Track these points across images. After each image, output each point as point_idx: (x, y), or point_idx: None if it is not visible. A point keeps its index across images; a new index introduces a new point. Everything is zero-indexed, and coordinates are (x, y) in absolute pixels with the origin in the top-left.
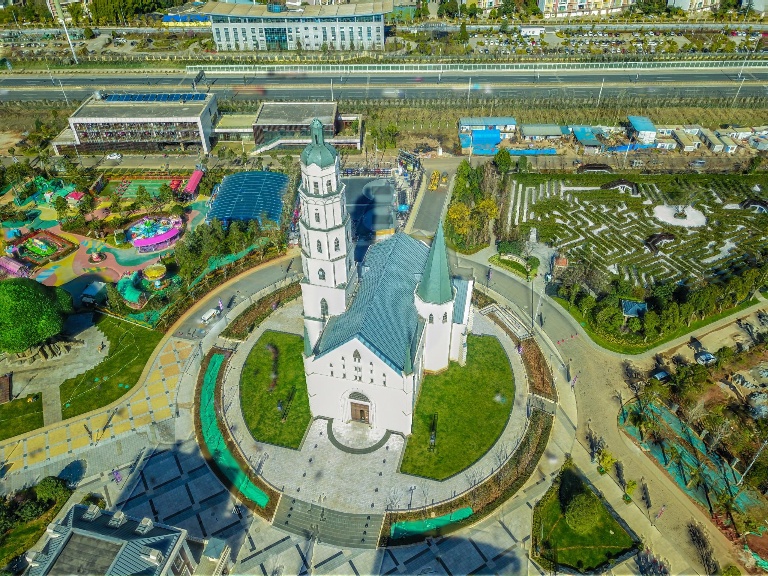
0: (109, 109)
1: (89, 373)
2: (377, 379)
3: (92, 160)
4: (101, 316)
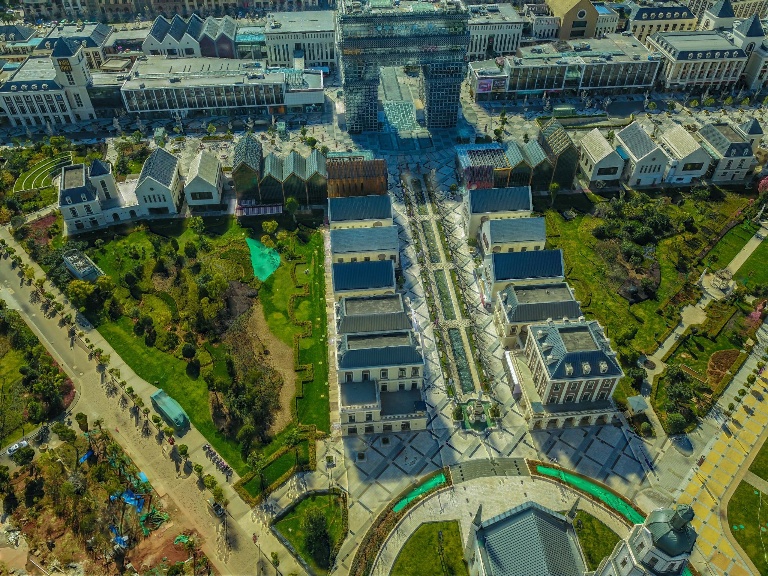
0: None
1: None
2: None
3: None
4: None
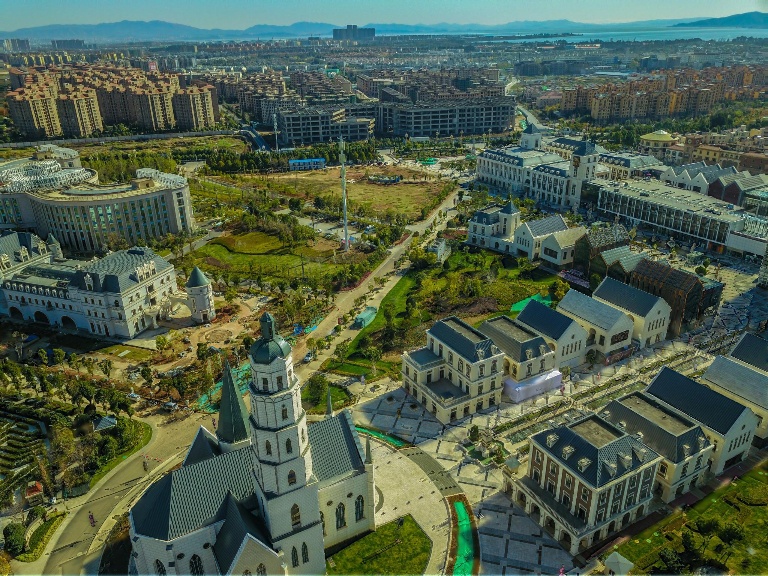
0: None
1: None
2: None
3: None
4: None
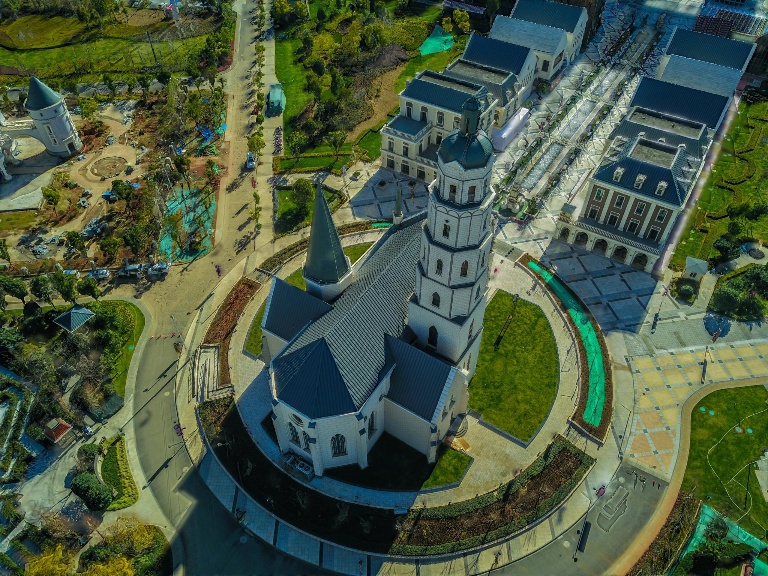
0: None
1: (767, 444)
2: None
3: None
4: None
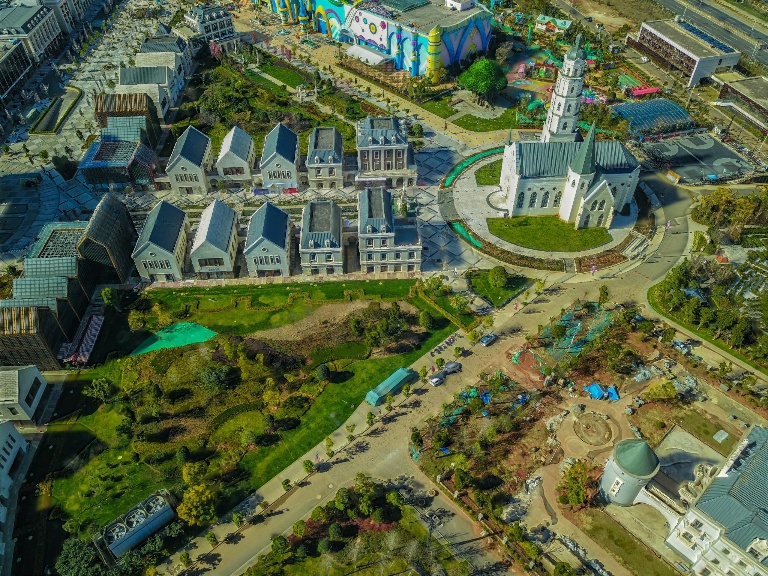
0: (670, 29)
1: (478, 118)
2: (513, 172)
3: (634, 55)
4: (514, 108)
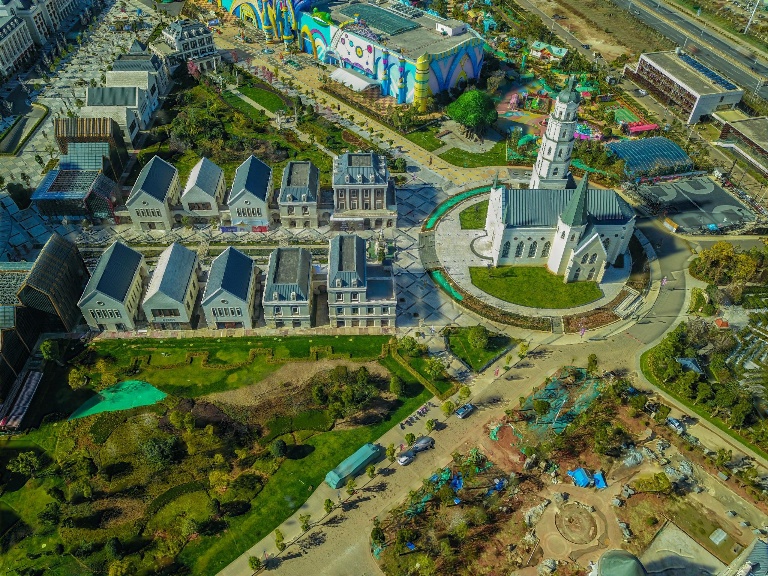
0: (670, 62)
1: (466, 152)
2: None
3: (631, 87)
4: (504, 142)
